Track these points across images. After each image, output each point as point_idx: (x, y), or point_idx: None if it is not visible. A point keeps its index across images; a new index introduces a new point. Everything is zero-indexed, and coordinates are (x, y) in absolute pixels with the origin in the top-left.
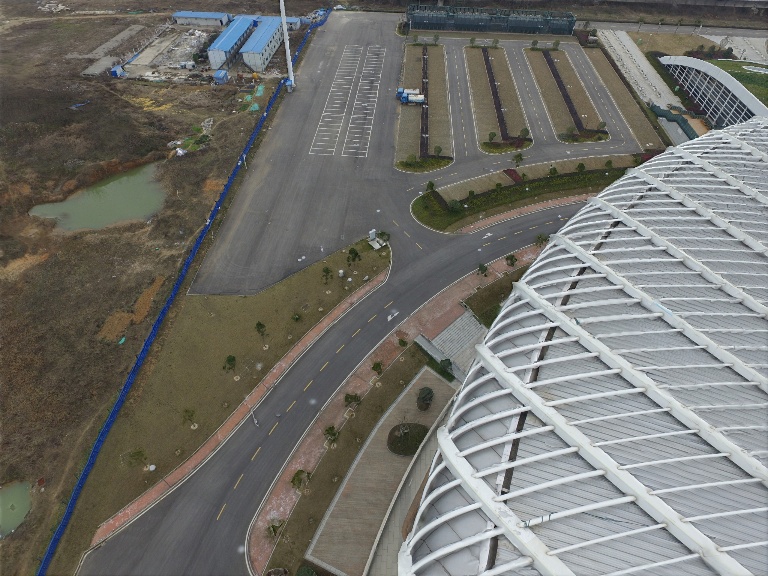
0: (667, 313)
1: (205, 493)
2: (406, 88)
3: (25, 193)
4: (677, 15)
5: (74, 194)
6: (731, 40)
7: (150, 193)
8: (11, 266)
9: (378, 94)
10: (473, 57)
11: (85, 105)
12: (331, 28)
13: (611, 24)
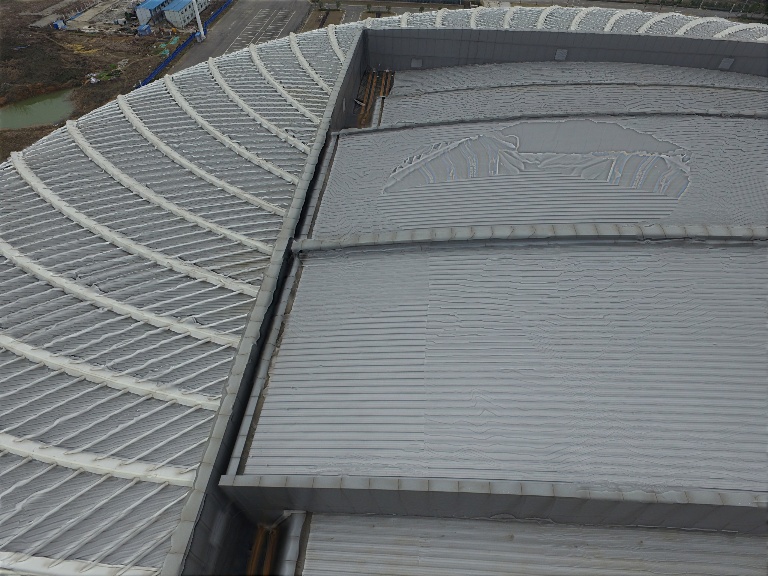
0: (212, 70)
1: None
2: None
3: None
4: None
5: (3, 107)
6: None
7: (64, 108)
8: None
9: None
10: None
11: (26, 48)
12: None
13: None
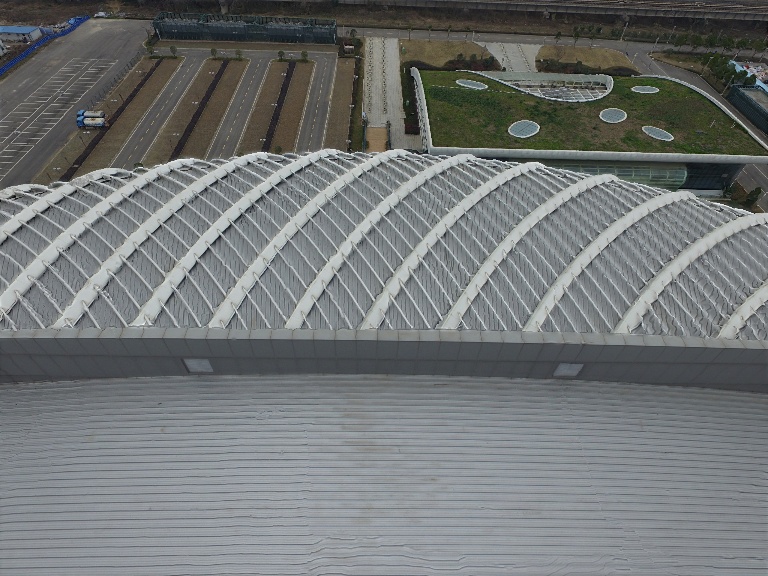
0: None
1: None
2: (88, 110)
3: None
4: (465, 20)
5: None
6: (503, 47)
7: None
8: None
9: (63, 117)
10: (207, 71)
11: None
12: (72, 39)
13: (389, 31)
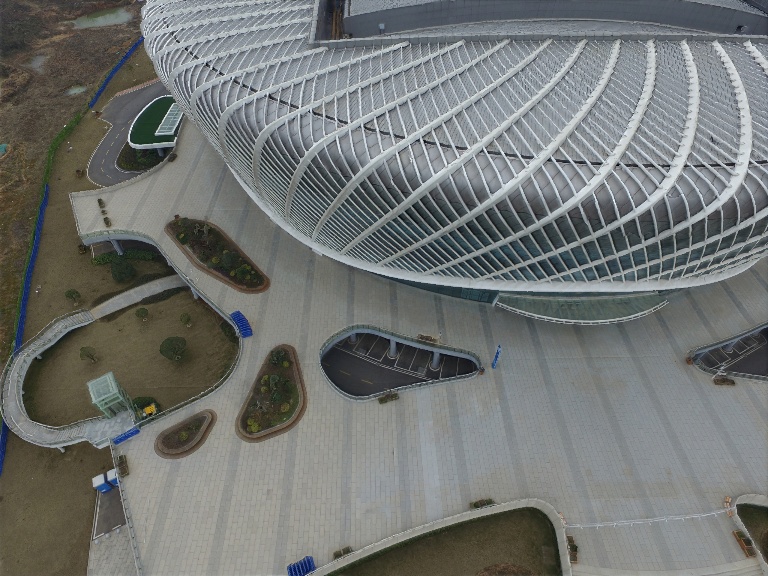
0: None
1: (160, 86)
2: None
3: (54, 14)
4: None
5: (81, 17)
6: None
7: None
8: (55, 37)
9: None
10: None
11: None
12: None
13: None
